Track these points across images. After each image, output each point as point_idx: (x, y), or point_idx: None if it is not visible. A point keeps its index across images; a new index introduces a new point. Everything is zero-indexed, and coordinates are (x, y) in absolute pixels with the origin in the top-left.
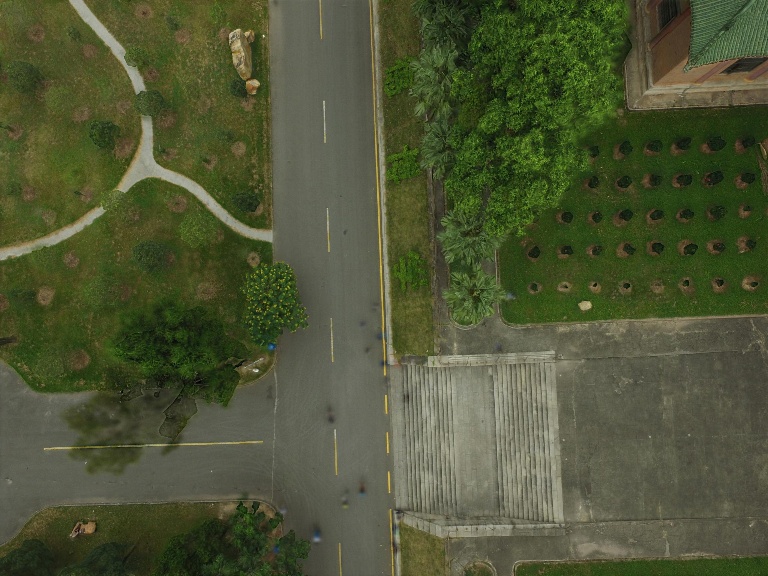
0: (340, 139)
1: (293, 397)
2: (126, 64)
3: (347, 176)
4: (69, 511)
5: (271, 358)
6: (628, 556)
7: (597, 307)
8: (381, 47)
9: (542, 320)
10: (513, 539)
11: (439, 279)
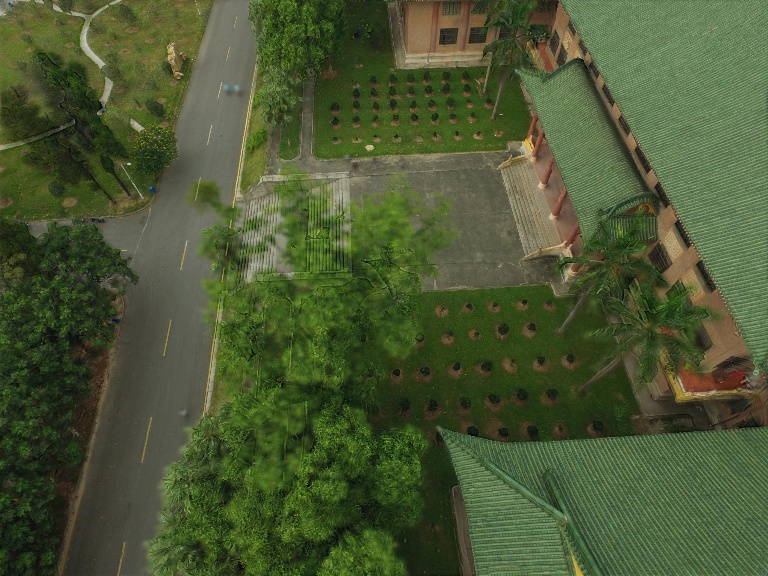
0: (228, 97)
1: (160, 222)
2: None
3: (228, 112)
4: None
5: (150, 199)
6: None
7: (378, 149)
8: None
9: (341, 156)
10: (309, 281)
11: (273, 139)
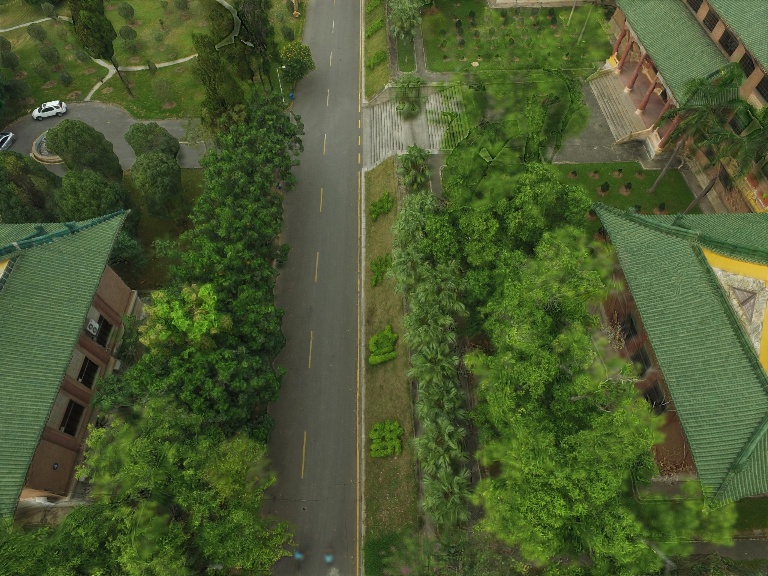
0: (341, 32)
1: None
2: (232, 11)
3: (343, 42)
4: None
5: None
6: (517, 163)
7: (482, 65)
8: (365, 3)
9: (451, 70)
10: (439, 155)
11: (392, 57)
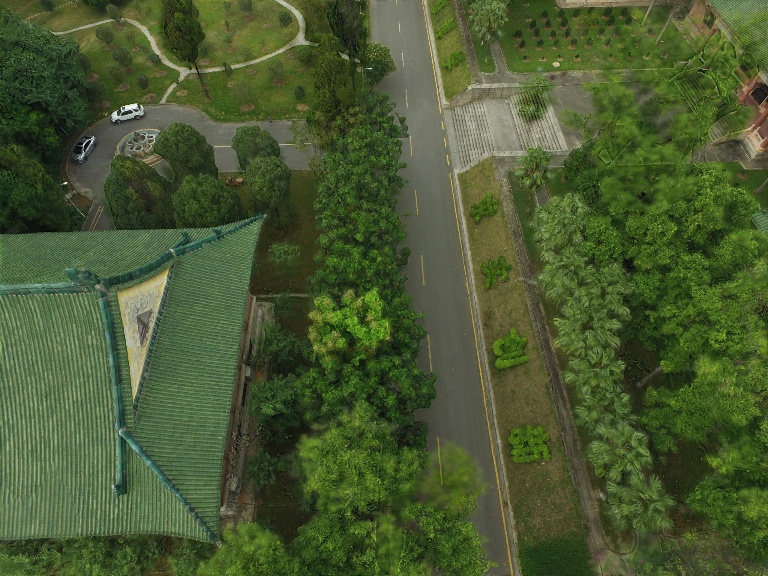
0: (408, 32)
1: None
2: (294, 12)
3: (413, 43)
4: (224, 175)
5: None
6: (616, 164)
7: (563, 66)
8: (429, 3)
9: (533, 71)
10: None
11: (470, 58)
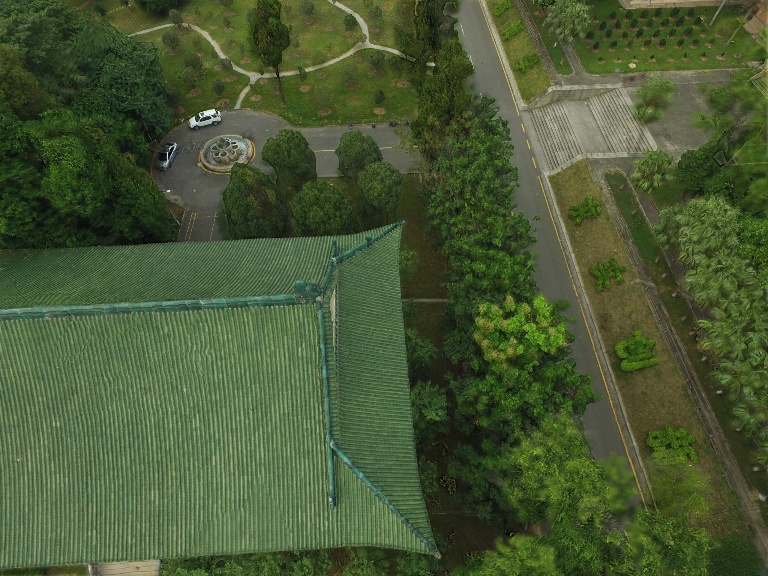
0: (472, 35)
1: None
2: (354, 15)
3: (479, 45)
4: None
5: None
6: None
7: (639, 67)
8: (488, 5)
9: (610, 72)
10: (630, 158)
11: None
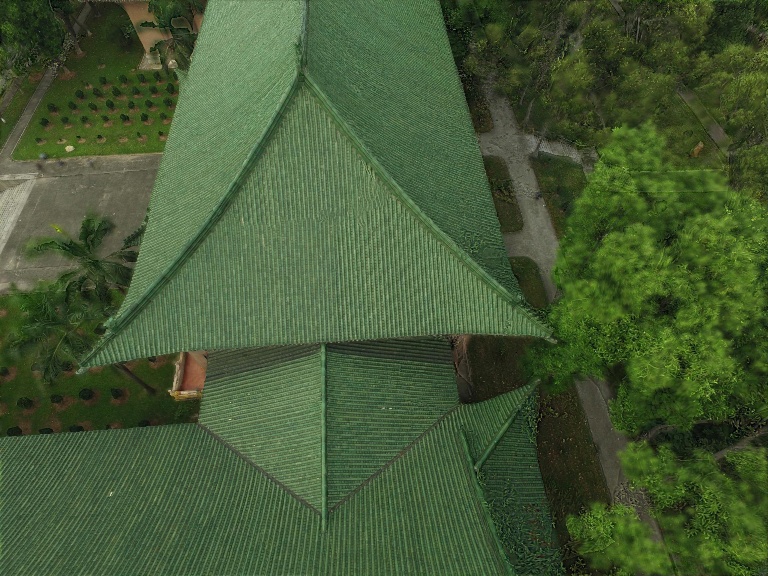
0: None
1: None
2: None
3: None
4: None
5: None
6: (33, 291)
7: (78, 150)
8: None
9: (38, 157)
10: None
11: None
